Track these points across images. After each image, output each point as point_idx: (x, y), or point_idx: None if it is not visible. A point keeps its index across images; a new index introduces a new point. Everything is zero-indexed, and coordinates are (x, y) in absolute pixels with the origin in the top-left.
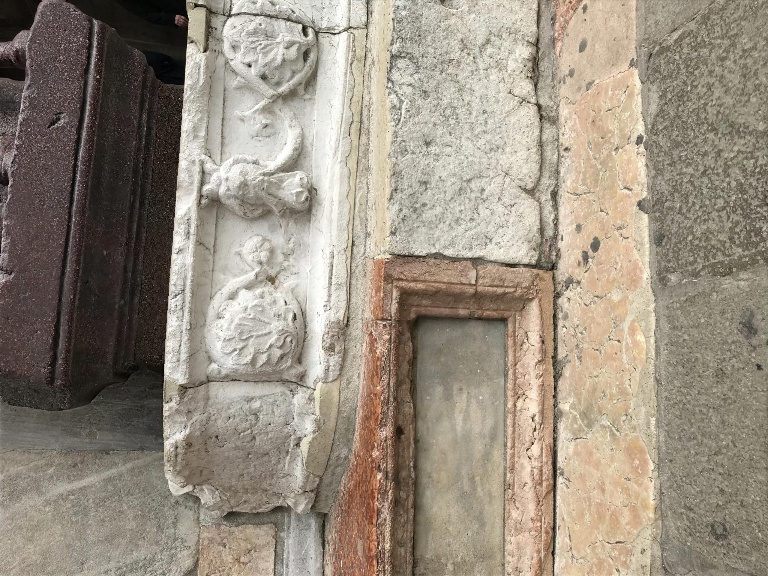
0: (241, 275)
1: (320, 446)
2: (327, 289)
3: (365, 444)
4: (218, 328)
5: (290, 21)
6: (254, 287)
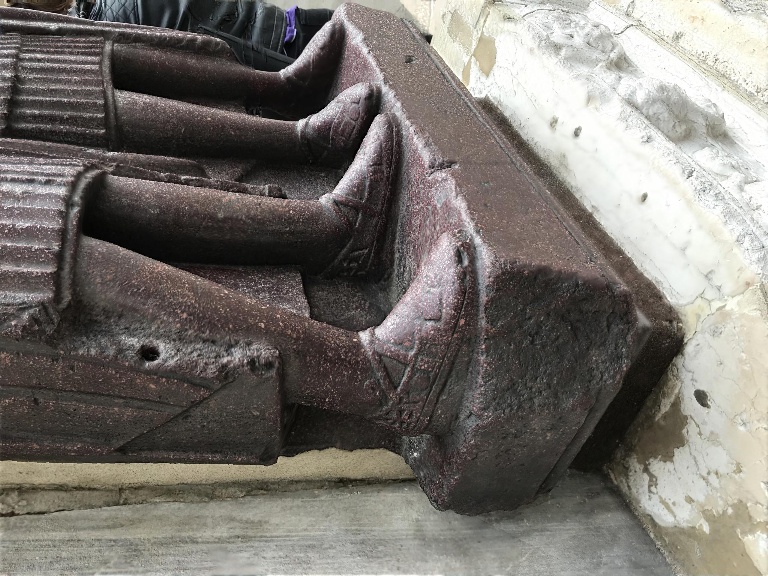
0: None
1: None
2: None
3: None
4: None
5: None
6: None
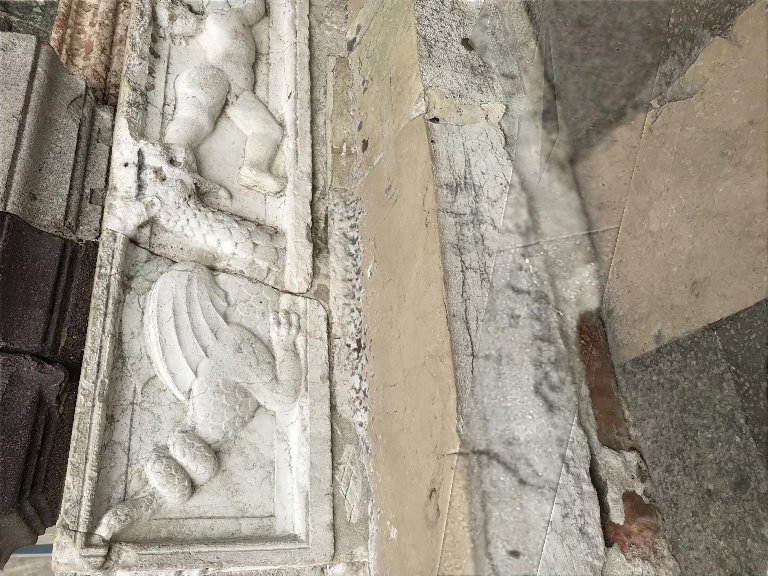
0: None
1: None
2: None
3: None
4: None
5: None
6: None
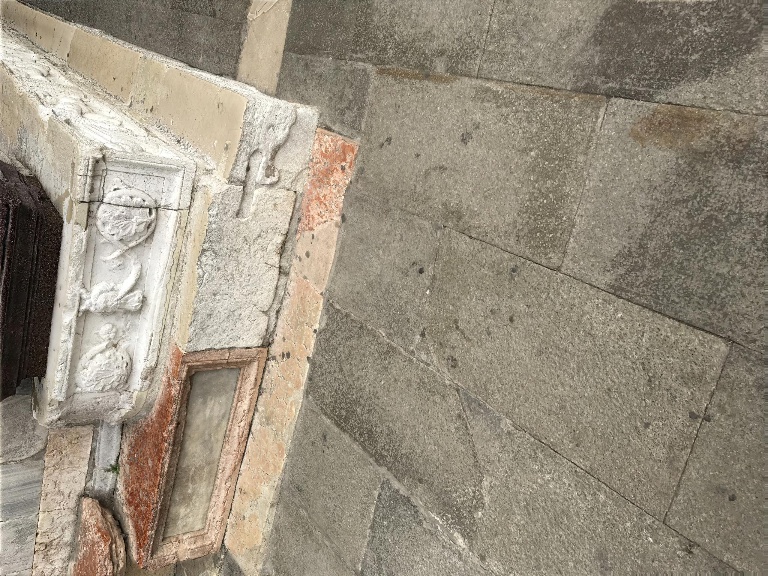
0: (97, 344)
1: (132, 413)
2: (147, 352)
3: (159, 424)
4: (84, 375)
5: (142, 208)
6: (105, 351)
